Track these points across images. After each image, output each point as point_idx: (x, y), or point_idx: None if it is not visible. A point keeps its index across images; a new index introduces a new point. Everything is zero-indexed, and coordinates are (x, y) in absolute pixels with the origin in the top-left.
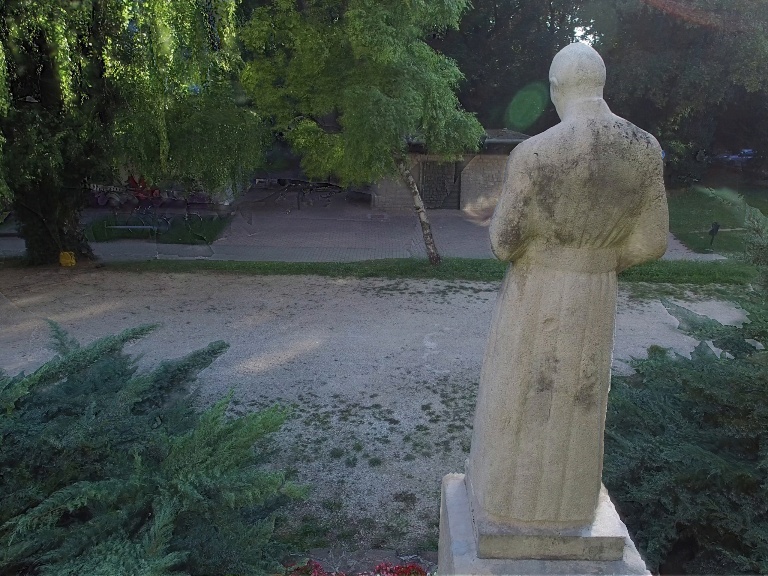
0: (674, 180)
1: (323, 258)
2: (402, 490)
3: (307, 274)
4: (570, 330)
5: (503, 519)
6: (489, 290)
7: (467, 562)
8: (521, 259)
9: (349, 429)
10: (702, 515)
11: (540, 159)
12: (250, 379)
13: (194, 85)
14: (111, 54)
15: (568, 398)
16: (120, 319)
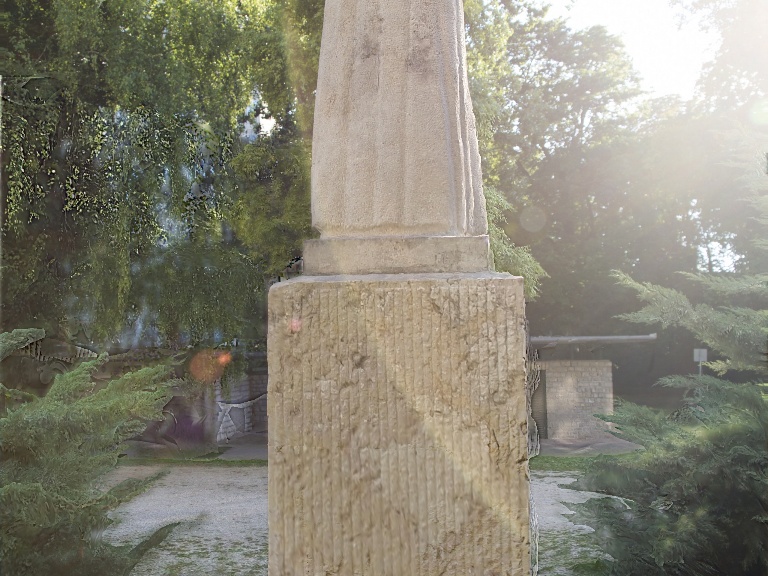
0: None
1: None
2: None
3: None
4: None
5: (338, 233)
6: (560, 476)
7: None
8: None
9: None
10: (741, 476)
11: None
12: (185, 526)
13: (172, 222)
14: (76, 184)
15: (399, 62)
16: None
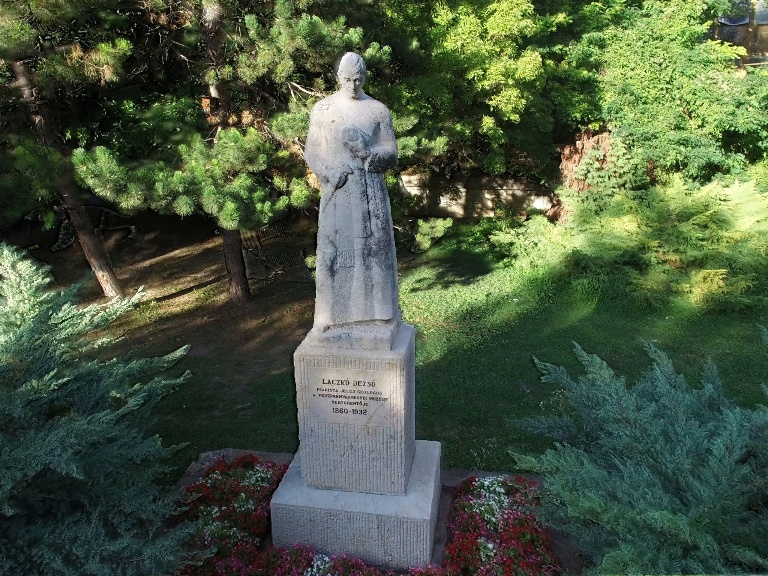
0: None
1: None
2: None
3: None
4: None
5: None
6: None
7: None
8: None
9: None
10: None
11: None
12: None
13: None
14: None
15: None
16: None
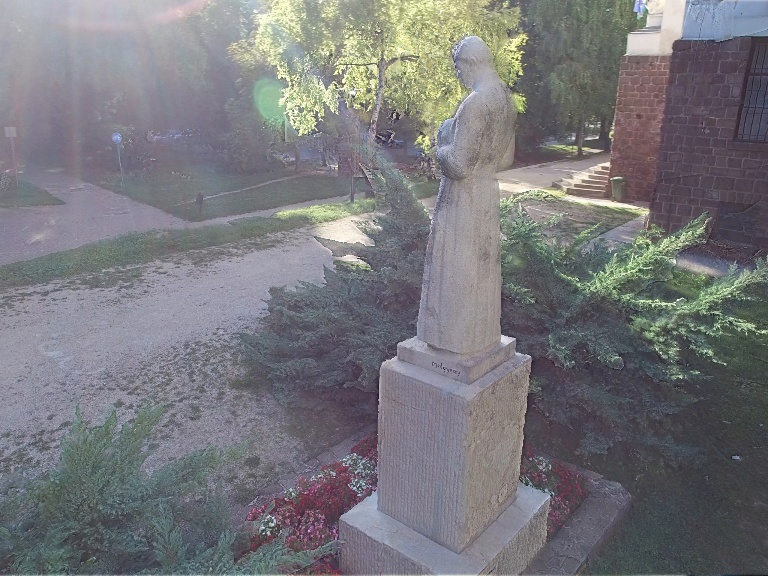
0: (134, 161)
1: None
2: None
3: None
4: (495, 217)
5: (470, 355)
6: (57, 290)
7: (466, 390)
8: (468, 177)
9: None
10: None
11: (489, 108)
12: None
13: None
14: None
15: (495, 261)
16: None
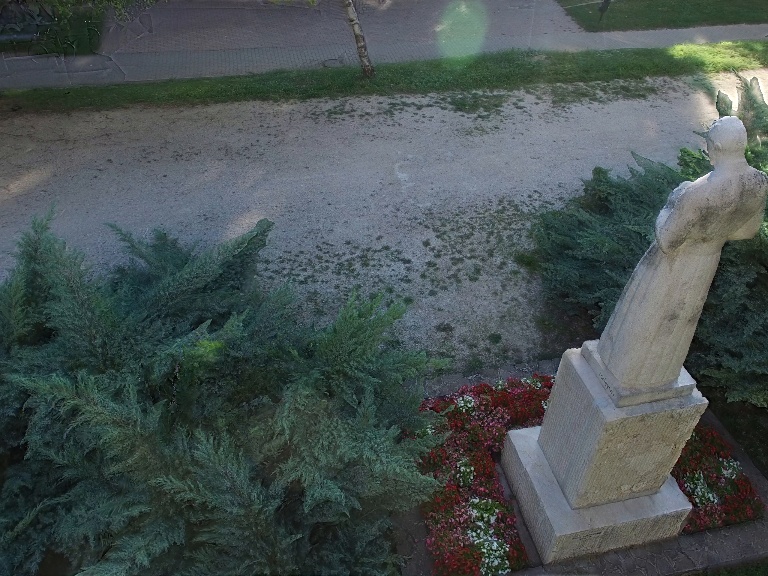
0: None
1: (234, 64)
2: (439, 322)
3: (248, 100)
4: (697, 287)
5: (631, 385)
6: (430, 105)
7: (611, 411)
8: None
9: (374, 274)
10: None
11: (710, 203)
12: None
13: None
14: None
15: (685, 321)
16: (91, 179)
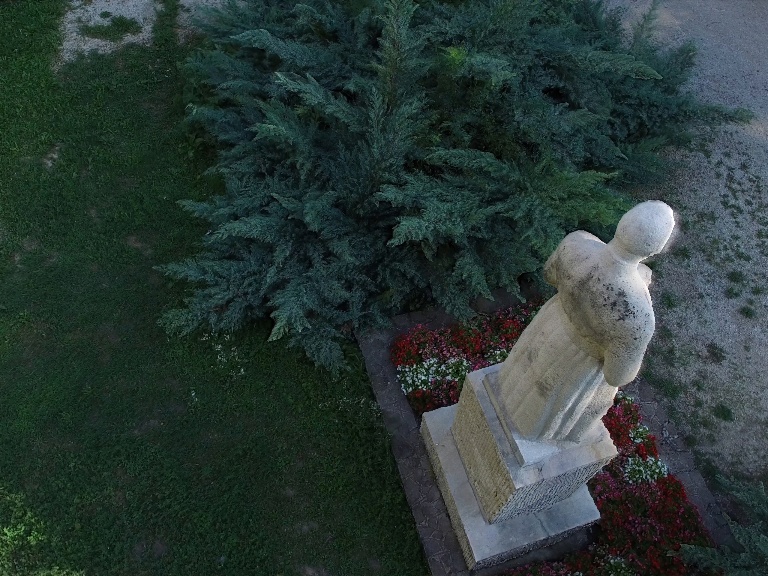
0: None
1: None
2: (724, 347)
3: None
4: None
5: None
6: None
7: (479, 376)
8: None
9: None
10: None
11: None
12: None
13: None
14: None
15: None
16: None
